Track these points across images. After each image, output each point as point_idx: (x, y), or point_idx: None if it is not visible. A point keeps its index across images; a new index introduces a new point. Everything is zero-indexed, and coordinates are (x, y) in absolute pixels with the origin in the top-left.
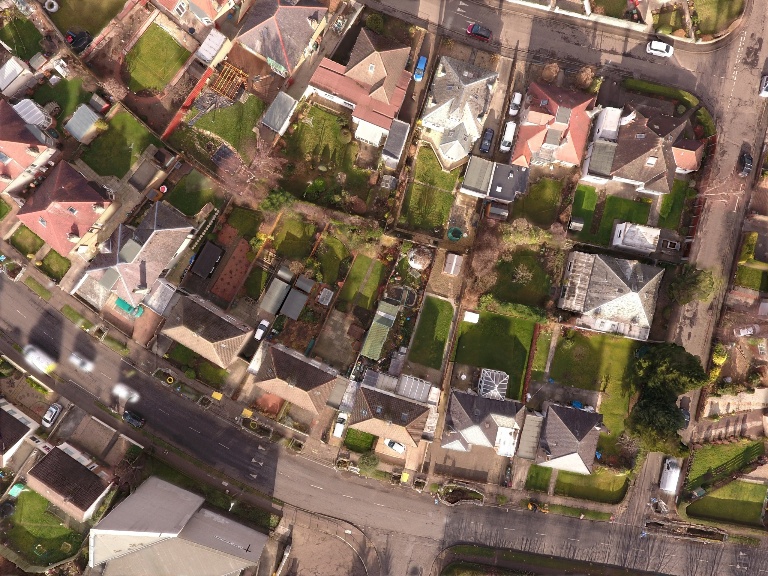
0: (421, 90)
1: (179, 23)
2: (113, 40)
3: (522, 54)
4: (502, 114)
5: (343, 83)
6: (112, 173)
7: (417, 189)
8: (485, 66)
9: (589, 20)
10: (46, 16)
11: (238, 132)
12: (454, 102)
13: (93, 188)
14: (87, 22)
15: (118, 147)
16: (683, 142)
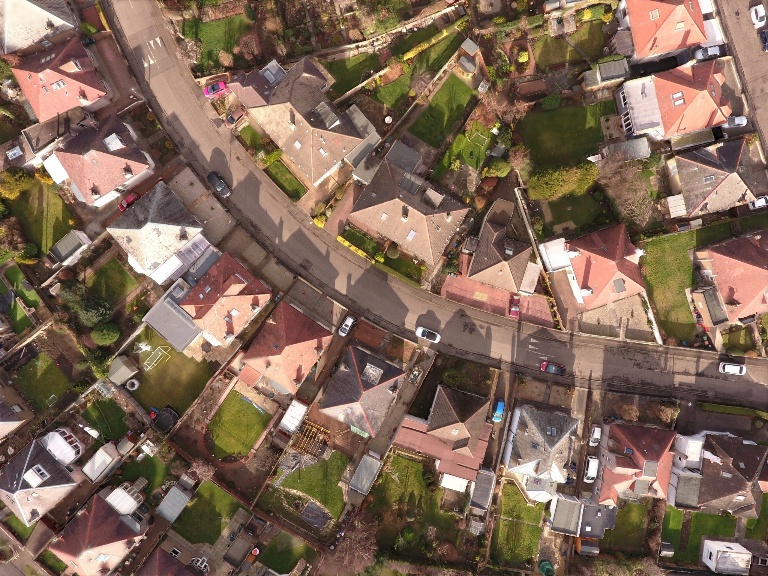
0: (500, 428)
1: (257, 386)
2: (195, 411)
3: (596, 383)
4: (582, 445)
5: (426, 441)
6: (204, 540)
7: (504, 525)
8: (561, 399)
9: (660, 346)
10: (130, 401)
11: (324, 488)
12: (541, 464)
13: (191, 572)
14: (168, 395)
15: (208, 514)
16: (767, 470)
